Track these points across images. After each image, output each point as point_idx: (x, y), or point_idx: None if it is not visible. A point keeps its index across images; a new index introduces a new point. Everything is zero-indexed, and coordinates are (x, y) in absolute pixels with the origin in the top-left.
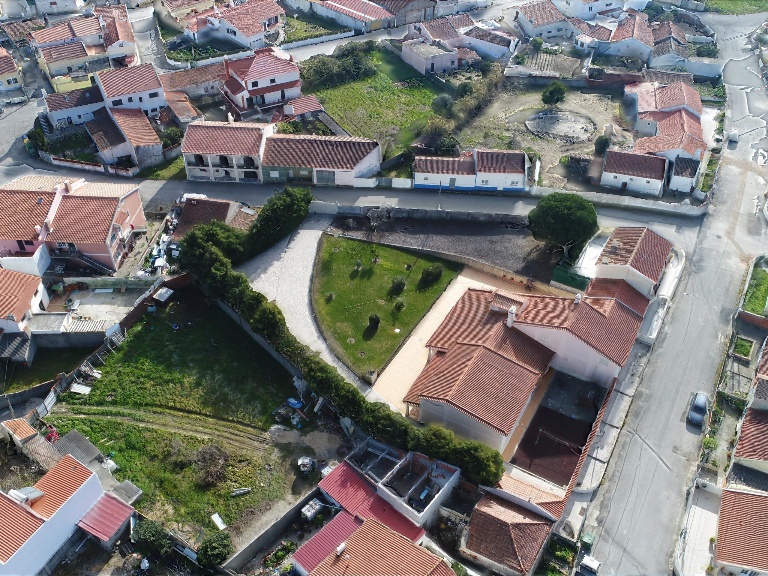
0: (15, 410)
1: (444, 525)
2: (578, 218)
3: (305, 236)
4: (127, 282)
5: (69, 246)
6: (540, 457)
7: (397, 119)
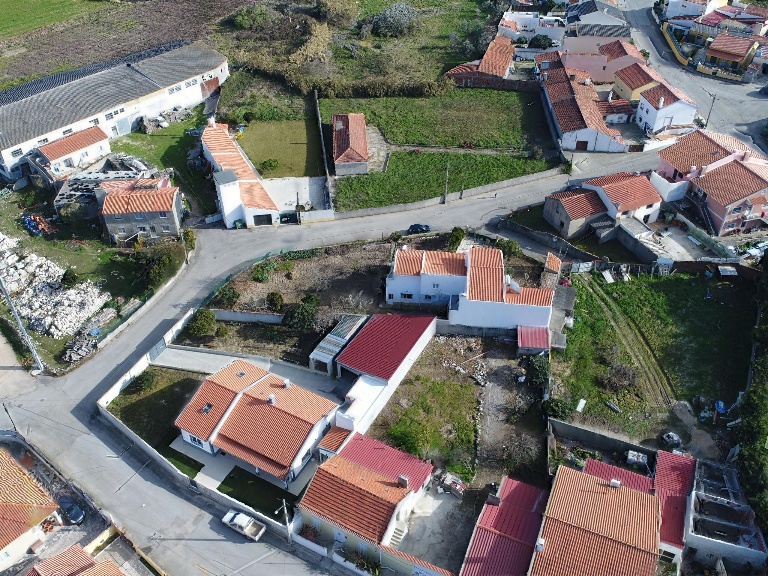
0: (566, 257)
1: (708, 573)
2: None
3: None
4: (714, 245)
5: (703, 195)
6: None
7: None
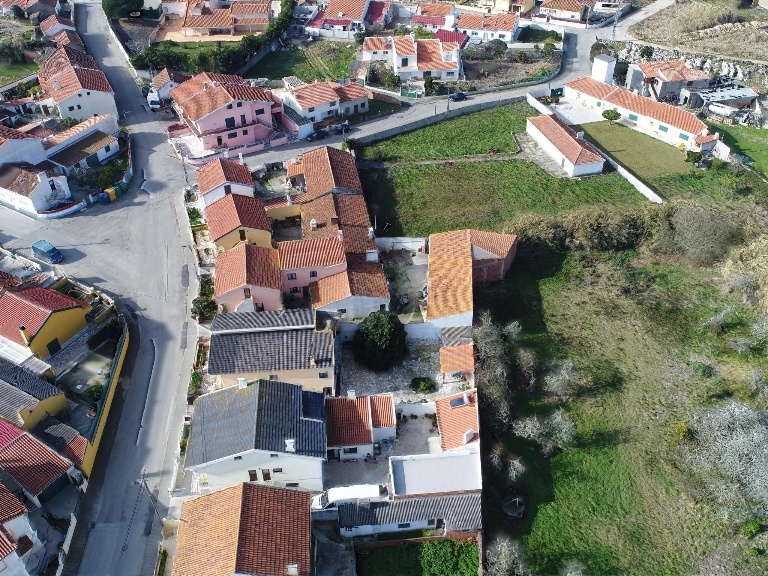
0: None
1: None
2: None
3: None
4: None
5: None
6: None
7: None
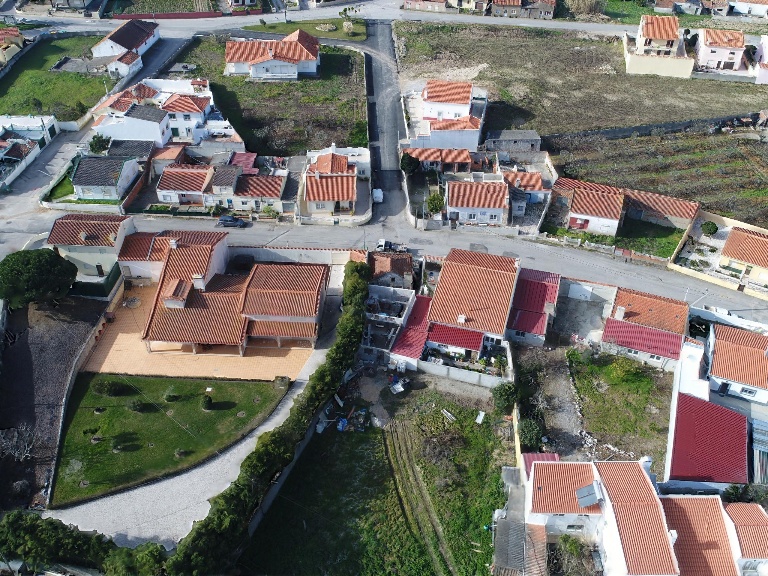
0: None
1: None
2: (53, 252)
3: None
4: None
5: None
6: None
7: None
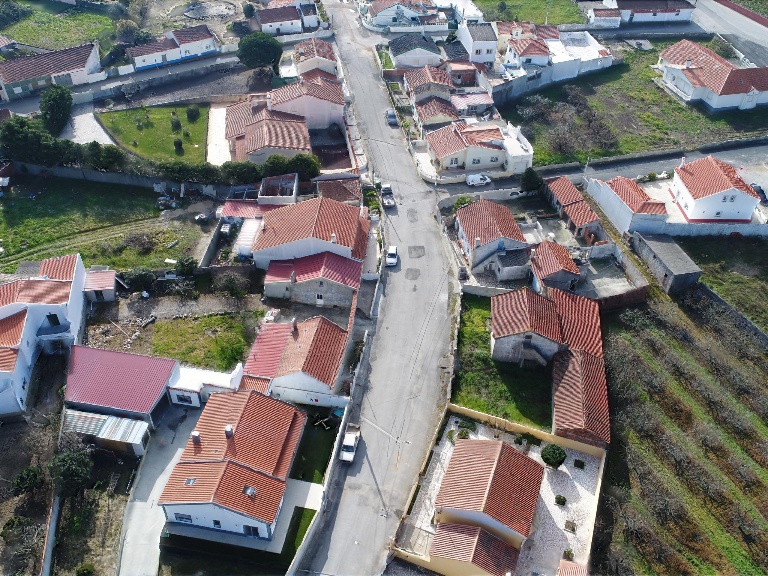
0: None
1: None
2: (271, 43)
3: (81, 119)
4: None
5: None
6: (330, 165)
7: (82, 37)
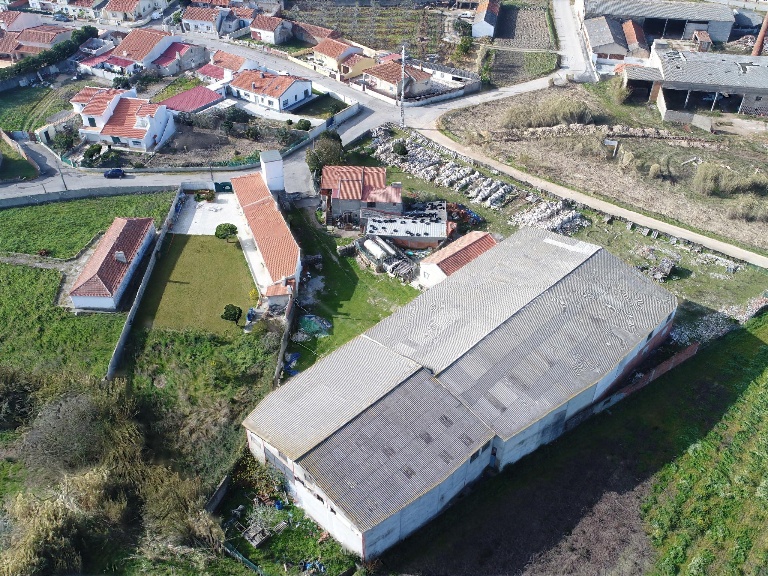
0: None
1: None
2: None
3: None
4: None
5: None
6: None
7: None
